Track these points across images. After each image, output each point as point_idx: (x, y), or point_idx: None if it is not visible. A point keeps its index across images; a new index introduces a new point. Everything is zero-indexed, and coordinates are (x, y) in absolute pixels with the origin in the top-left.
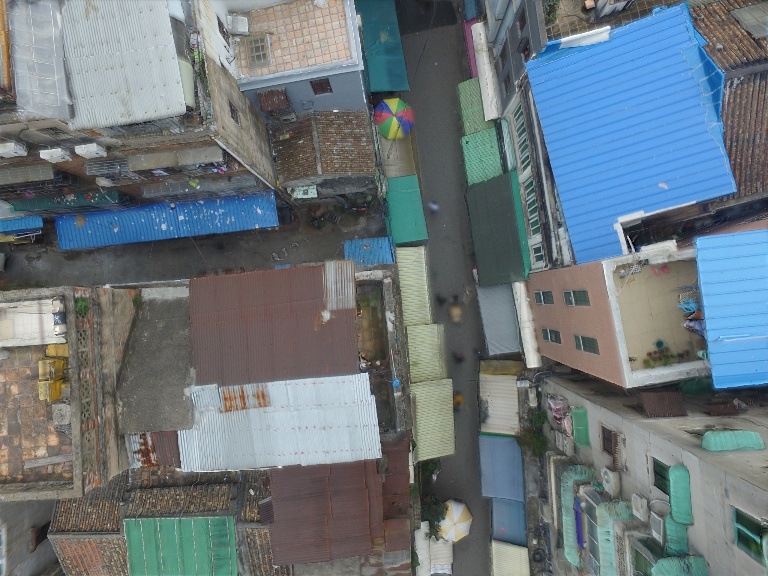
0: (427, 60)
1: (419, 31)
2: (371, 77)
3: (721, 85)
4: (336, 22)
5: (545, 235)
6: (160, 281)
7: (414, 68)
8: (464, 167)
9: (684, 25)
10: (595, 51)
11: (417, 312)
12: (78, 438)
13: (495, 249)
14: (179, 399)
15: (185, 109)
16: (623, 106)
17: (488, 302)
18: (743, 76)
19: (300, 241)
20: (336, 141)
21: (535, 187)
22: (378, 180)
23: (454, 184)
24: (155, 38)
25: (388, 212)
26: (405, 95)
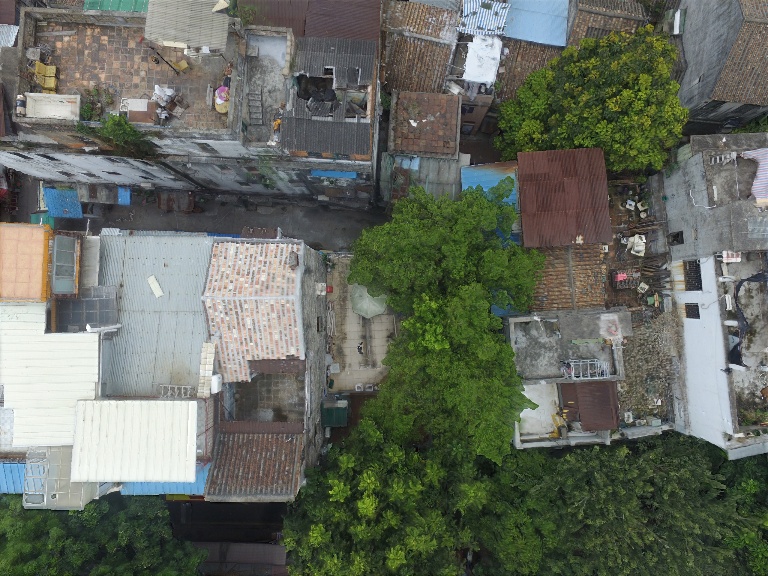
0: None
1: None
2: None
3: None
4: None
5: None
6: (68, 154)
7: None
8: None
9: None
10: None
11: None
12: (19, 38)
13: None
14: (5, 64)
15: None
16: None
17: None
18: None
19: None
20: None
21: None
22: None
23: None
24: None
25: None
26: None
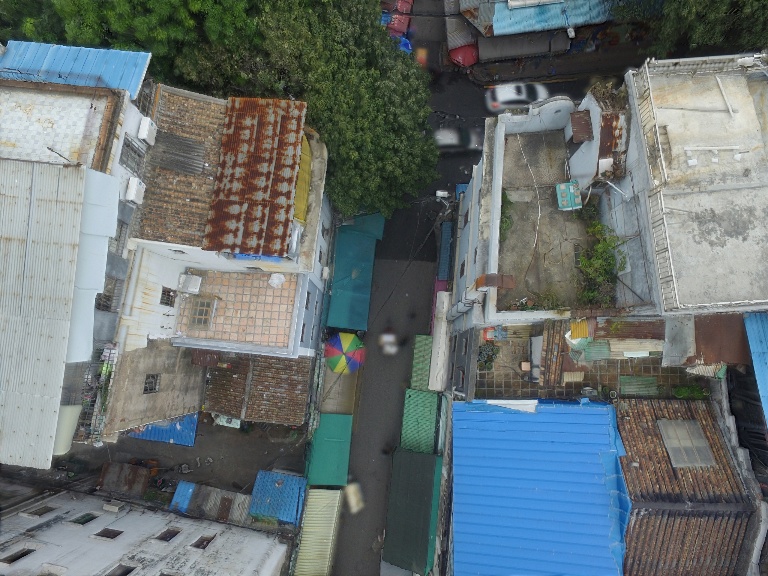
0: (399, 289)
1: (399, 259)
2: (331, 311)
3: (627, 512)
4: (284, 305)
5: (442, 565)
6: None
7: (385, 293)
8: (402, 418)
9: (607, 427)
10: (520, 417)
11: (314, 563)
12: None
13: (405, 528)
14: None
15: (50, 465)
16: (534, 485)
17: (389, 574)
18: (651, 508)
19: (224, 440)
20: (270, 385)
21: (444, 509)
22: (310, 415)
23: (394, 419)
24: (44, 387)
25: (310, 454)
26: (369, 317)
